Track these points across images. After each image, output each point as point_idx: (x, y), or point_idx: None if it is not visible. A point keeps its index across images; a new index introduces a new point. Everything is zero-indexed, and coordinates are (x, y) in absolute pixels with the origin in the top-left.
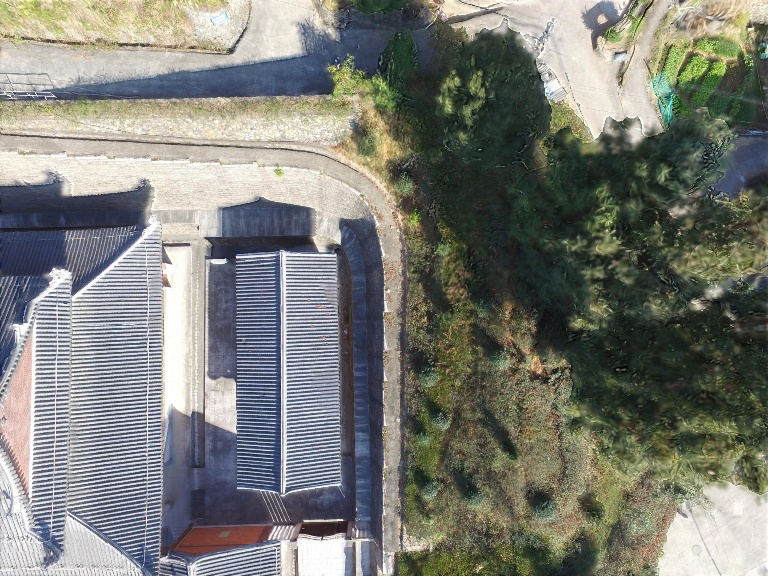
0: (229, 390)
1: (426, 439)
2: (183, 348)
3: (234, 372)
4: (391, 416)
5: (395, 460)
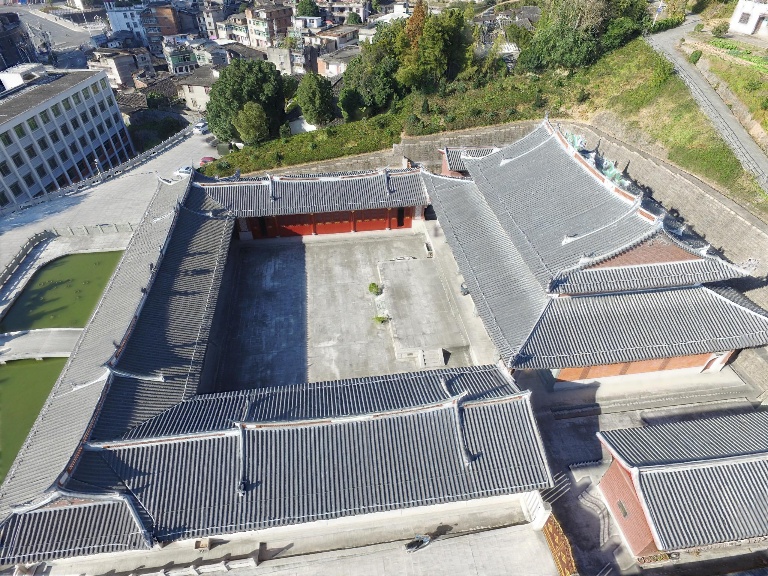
0: None
1: None
2: (653, 389)
3: None
4: None
5: None
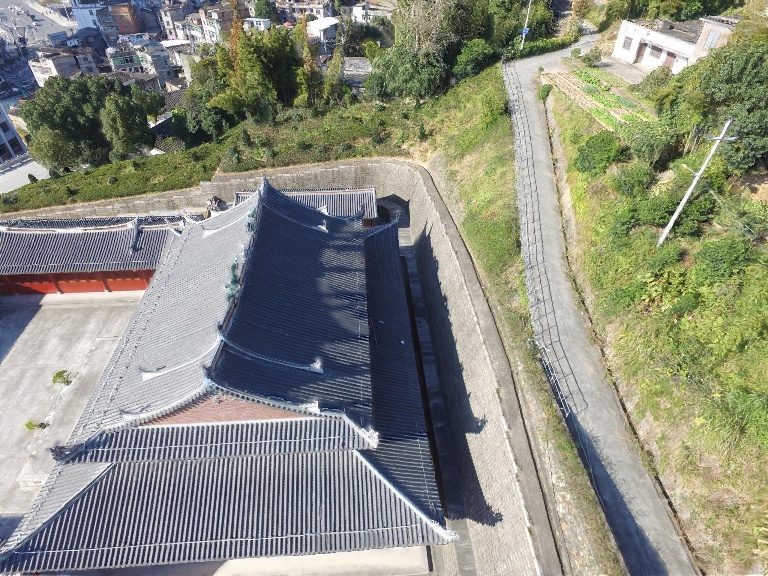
0: None
1: None
2: (297, 571)
3: None
4: None
5: None
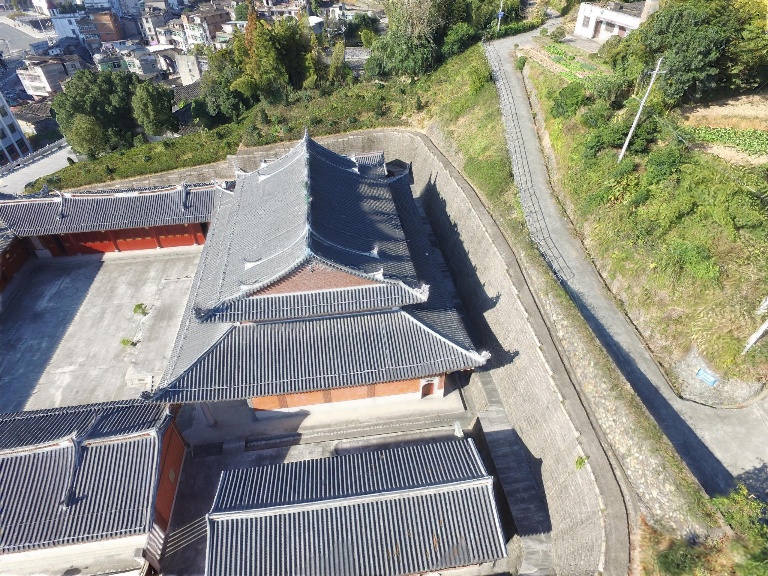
0: None
1: None
2: (365, 417)
3: None
4: None
5: None
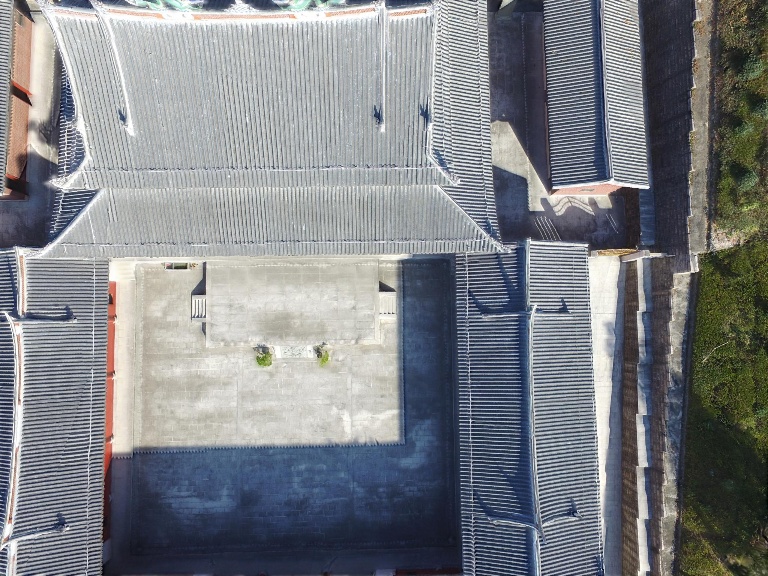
0: (504, 133)
1: (749, 127)
2: None
3: (509, 116)
4: (699, 121)
5: (703, 163)
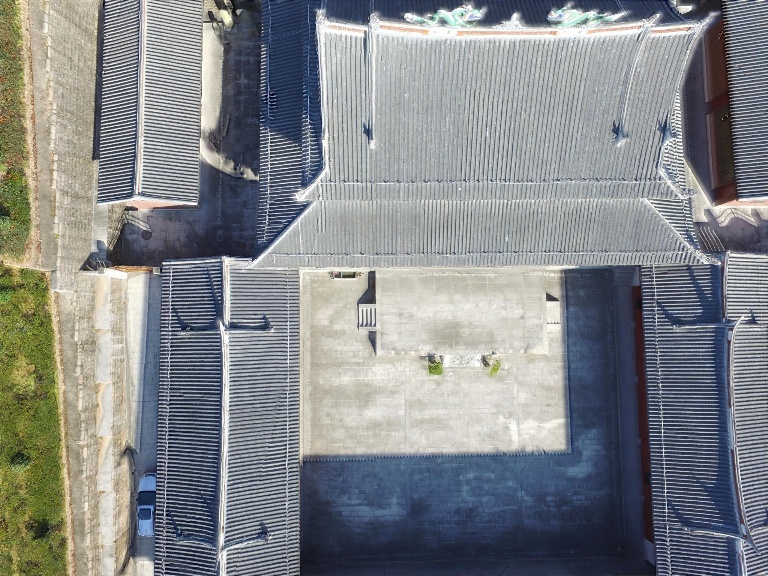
0: None
1: None
2: None
3: None
4: None
5: None
